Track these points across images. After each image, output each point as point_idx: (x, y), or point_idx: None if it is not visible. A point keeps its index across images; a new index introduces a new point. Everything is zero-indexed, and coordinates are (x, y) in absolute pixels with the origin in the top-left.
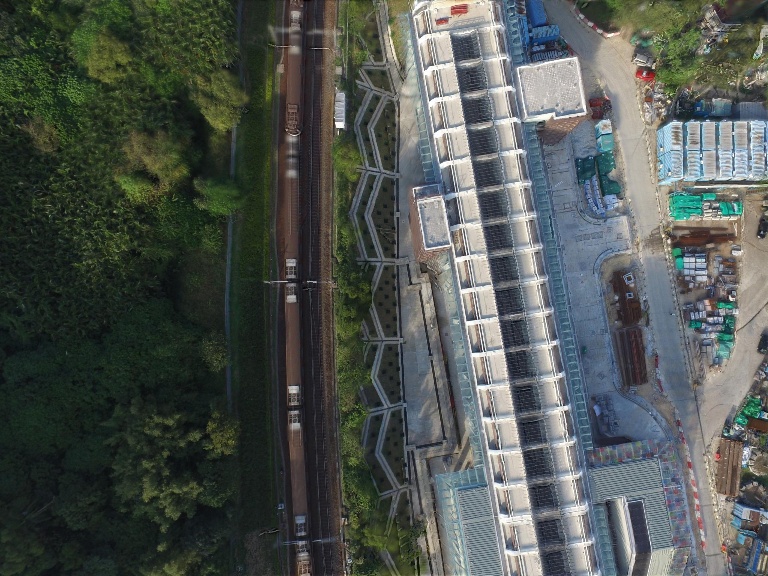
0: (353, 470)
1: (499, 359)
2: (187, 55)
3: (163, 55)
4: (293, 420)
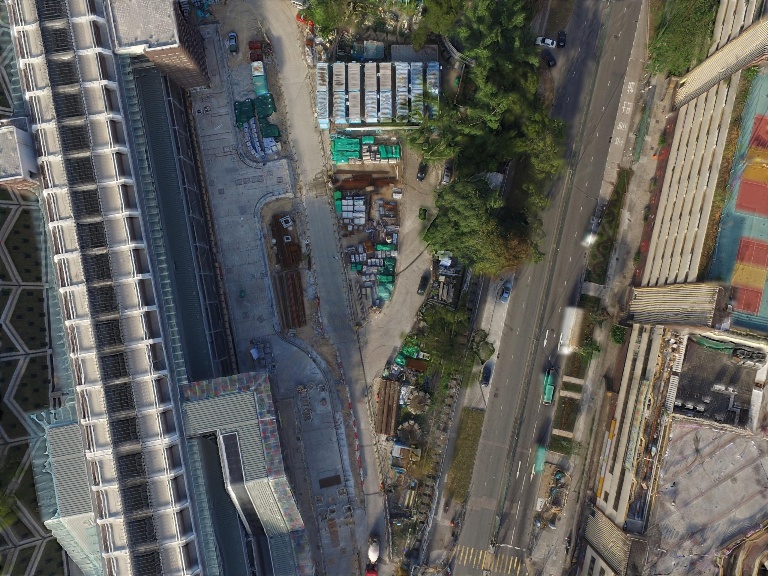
0: None
1: (81, 293)
2: None
3: None
4: None
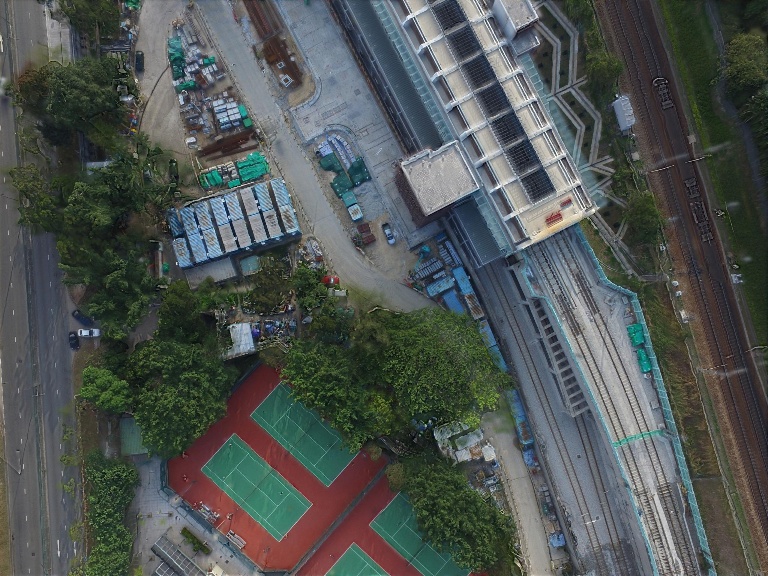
0: None
1: None
2: None
3: None
4: None
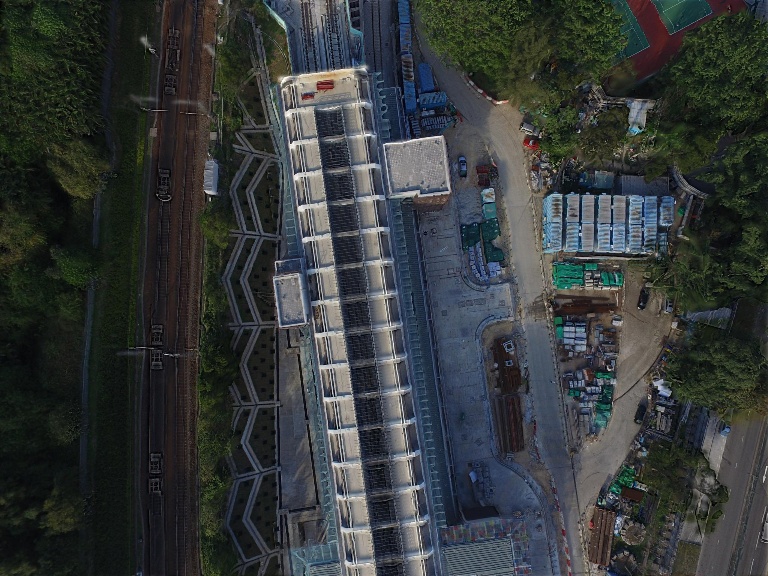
0: (209, 542)
1: (353, 437)
2: (43, 124)
3: (17, 124)
4: (154, 488)
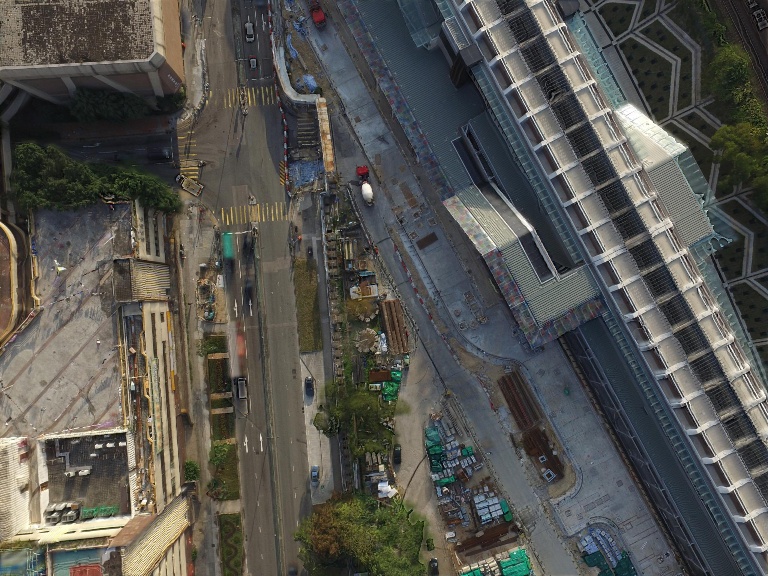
0: None
1: None
2: None
3: None
4: None
